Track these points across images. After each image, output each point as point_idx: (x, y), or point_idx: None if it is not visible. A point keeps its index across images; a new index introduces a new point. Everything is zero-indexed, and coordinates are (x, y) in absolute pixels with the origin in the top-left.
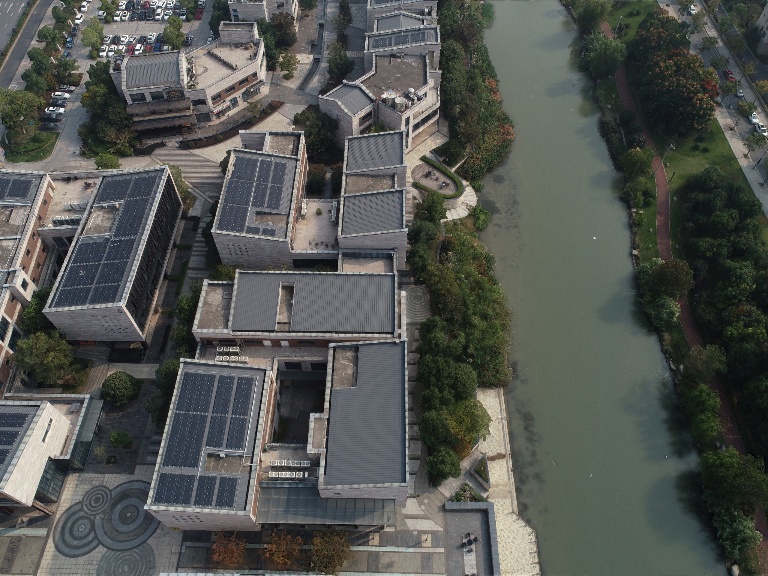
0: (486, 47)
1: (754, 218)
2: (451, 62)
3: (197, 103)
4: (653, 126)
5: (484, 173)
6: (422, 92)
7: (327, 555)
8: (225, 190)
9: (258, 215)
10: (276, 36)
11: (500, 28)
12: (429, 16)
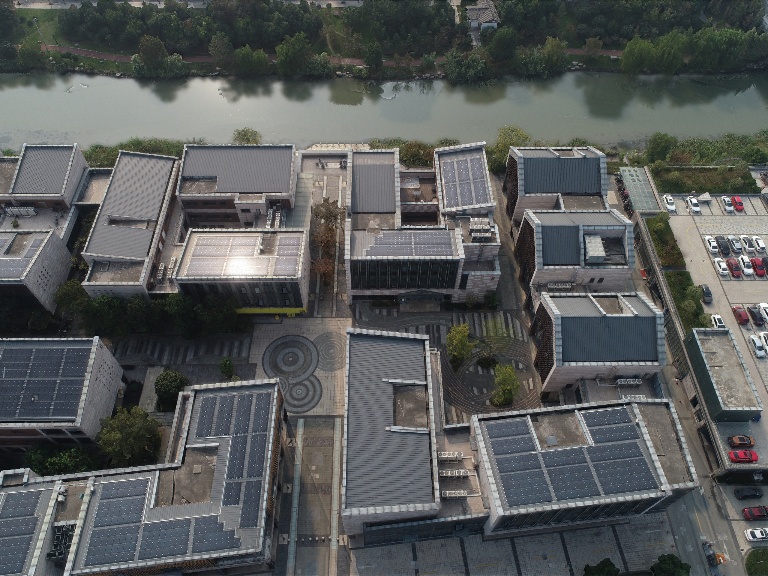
0: None
1: (117, 5)
2: None
3: None
4: None
5: None
6: None
7: (330, 209)
8: None
9: None
10: None
11: None
12: None
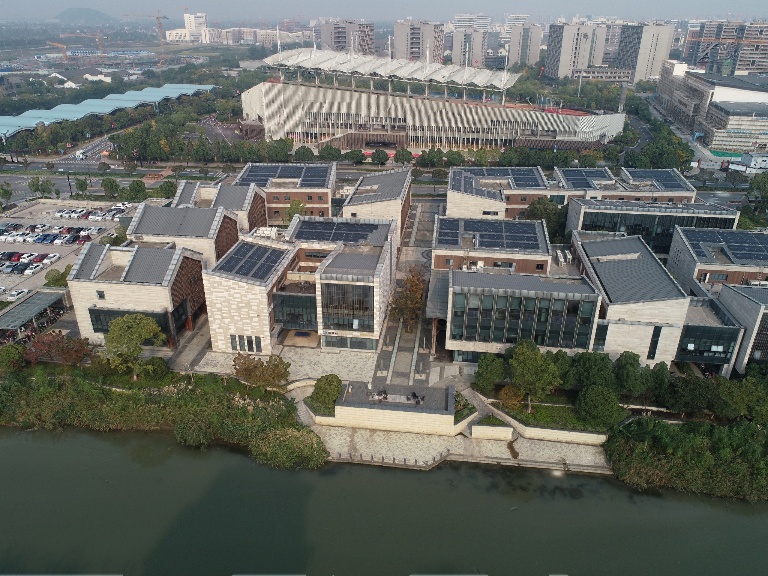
0: None
1: None
2: None
3: None
4: None
5: None
6: None
7: (407, 297)
8: (734, 232)
9: (721, 252)
10: None
11: None
12: None
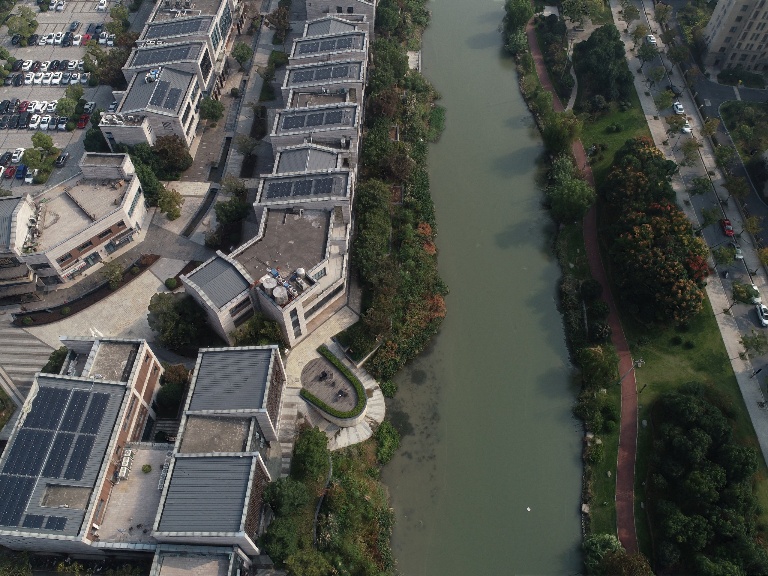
0: (427, 173)
1: (747, 479)
2: (369, 212)
3: (39, 266)
4: (624, 302)
5: (400, 368)
6: (318, 269)
7: None
8: (9, 448)
9: (51, 487)
10: (161, 163)
11: (449, 142)
12: (345, 149)
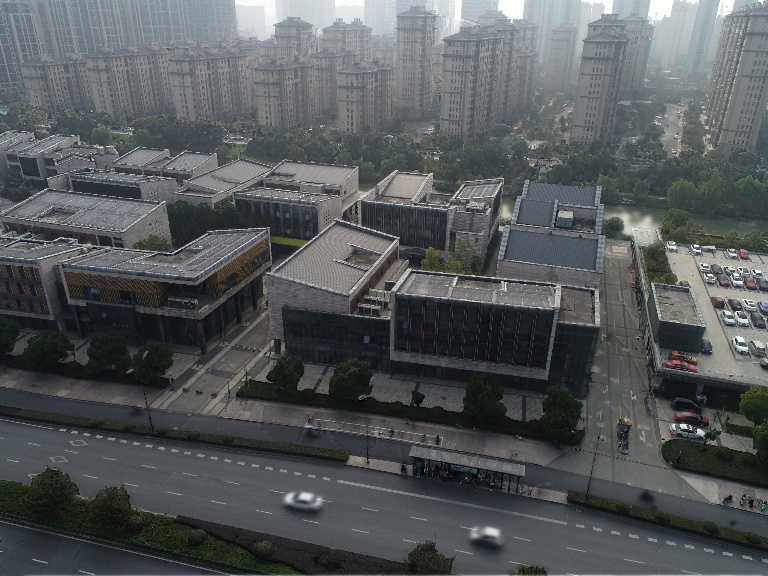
0: None
1: None
2: None
3: None
4: None
5: None
6: None
7: None
8: None
9: None
10: None
11: None
12: None
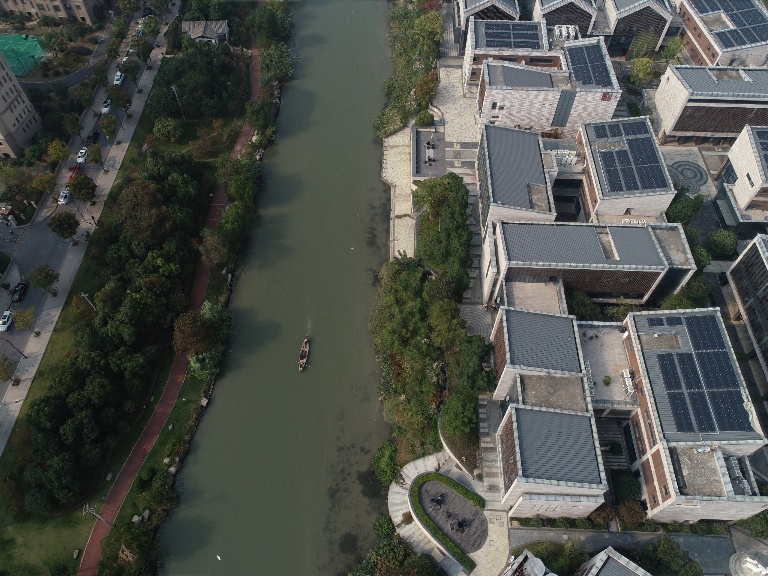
0: None
1: None
2: None
3: None
4: None
5: None
6: None
7: None
8: (736, 370)
9: None
10: None
11: None
12: None
